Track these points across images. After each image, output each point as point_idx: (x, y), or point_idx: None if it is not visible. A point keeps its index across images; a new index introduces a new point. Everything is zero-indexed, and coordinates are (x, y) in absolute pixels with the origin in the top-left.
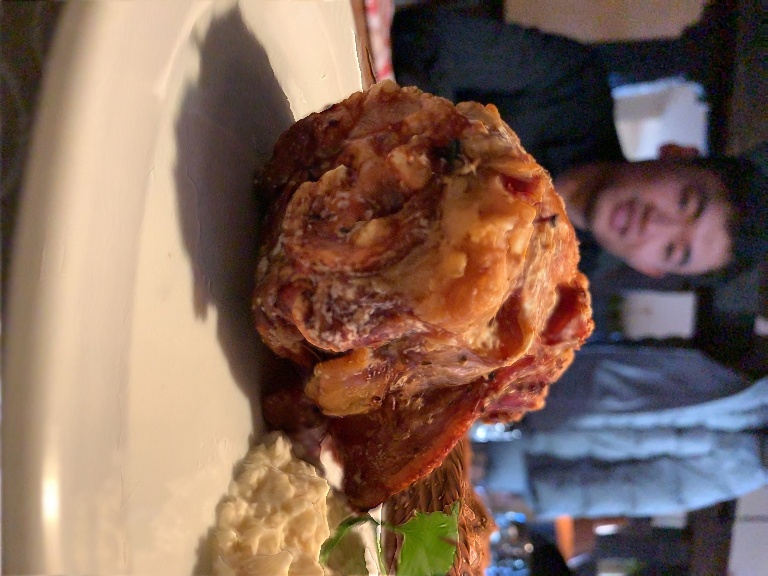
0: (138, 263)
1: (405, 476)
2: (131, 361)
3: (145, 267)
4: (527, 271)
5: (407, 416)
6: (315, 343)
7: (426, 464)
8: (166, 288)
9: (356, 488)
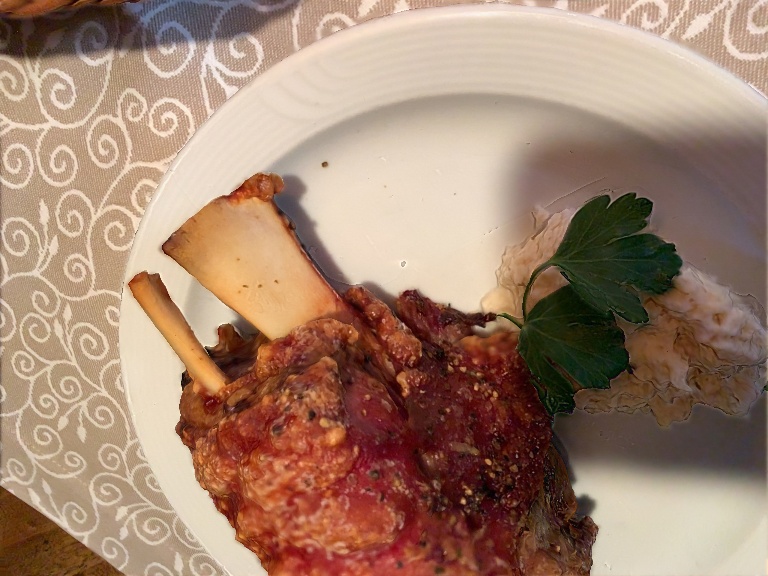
0: (635, 542)
1: None
2: (661, 516)
3: (630, 539)
4: None
5: None
6: None
7: None
8: (618, 525)
9: None
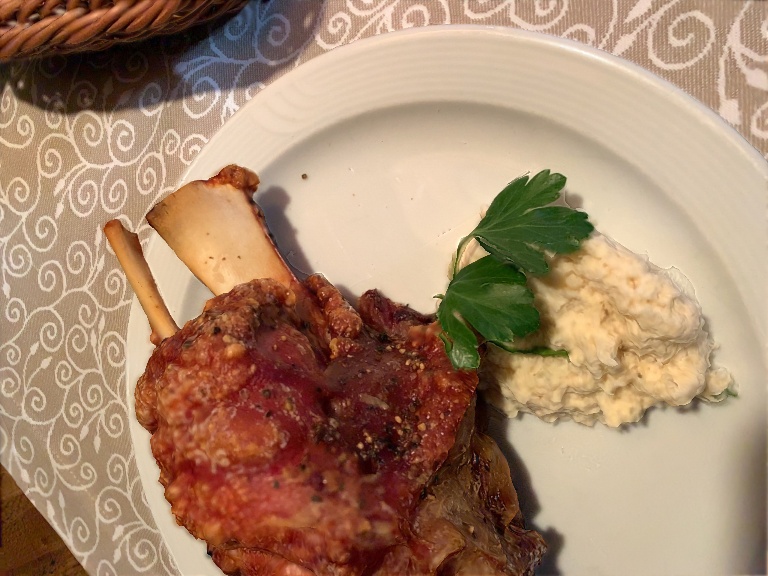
0: None
1: None
2: (639, 562)
3: None
4: None
5: None
6: None
7: None
8: (592, 570)
9: None
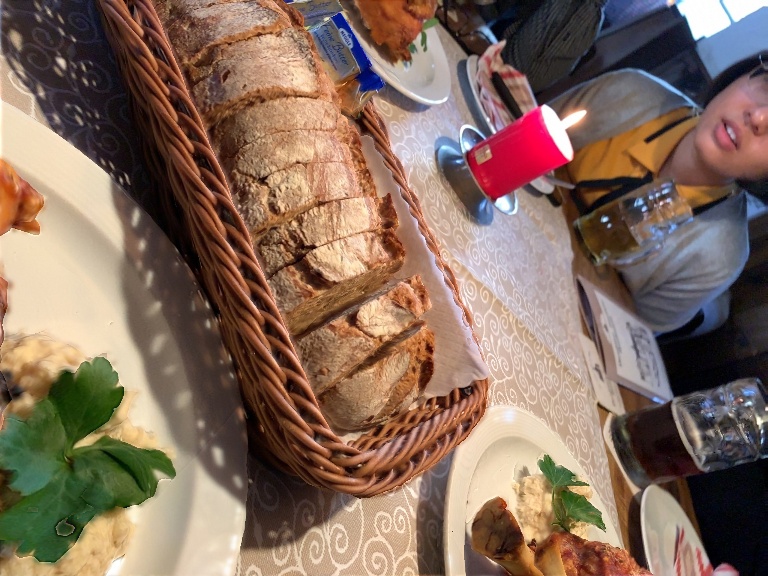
0: None
1: None
2: None
3: None
4: None
5: None
6: None
7: None
8: None
9: None
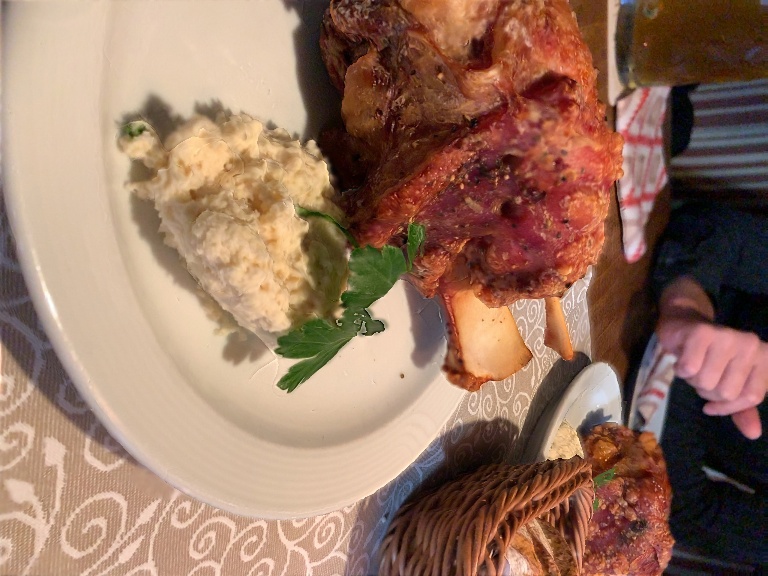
0: None
1: (387, 194)
2: None
3: None
4: (502, 10)
5: (401, 140)
6: (336, 20)
7: (404, 184)
8: None
9: (355, 210)
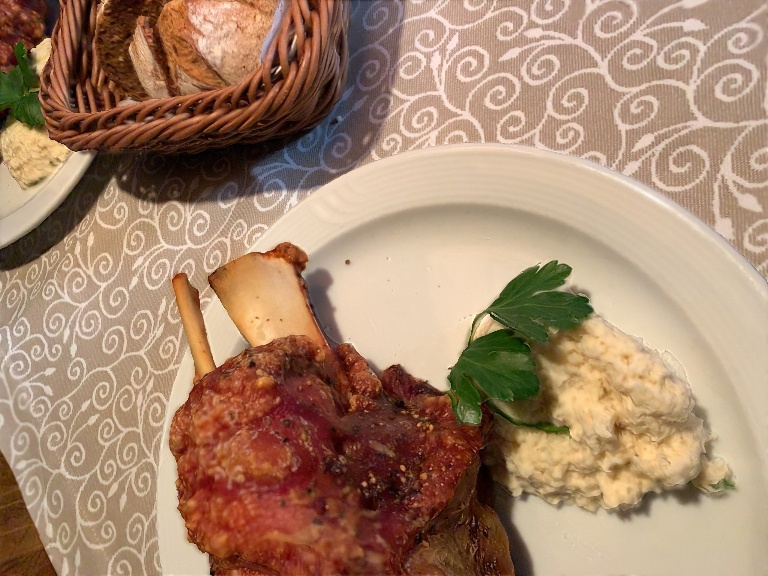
0: None
1: None
2: None
3: None
4: None
5: None
6: None
7: None
8: None
9: None
